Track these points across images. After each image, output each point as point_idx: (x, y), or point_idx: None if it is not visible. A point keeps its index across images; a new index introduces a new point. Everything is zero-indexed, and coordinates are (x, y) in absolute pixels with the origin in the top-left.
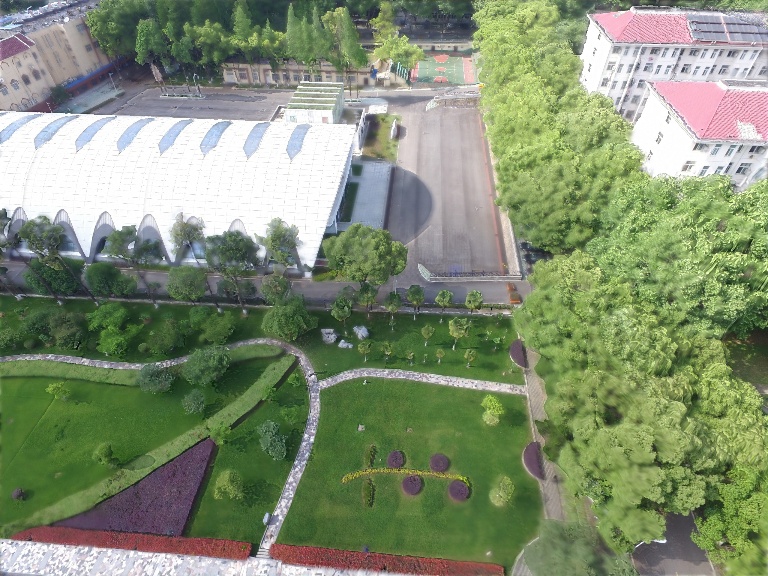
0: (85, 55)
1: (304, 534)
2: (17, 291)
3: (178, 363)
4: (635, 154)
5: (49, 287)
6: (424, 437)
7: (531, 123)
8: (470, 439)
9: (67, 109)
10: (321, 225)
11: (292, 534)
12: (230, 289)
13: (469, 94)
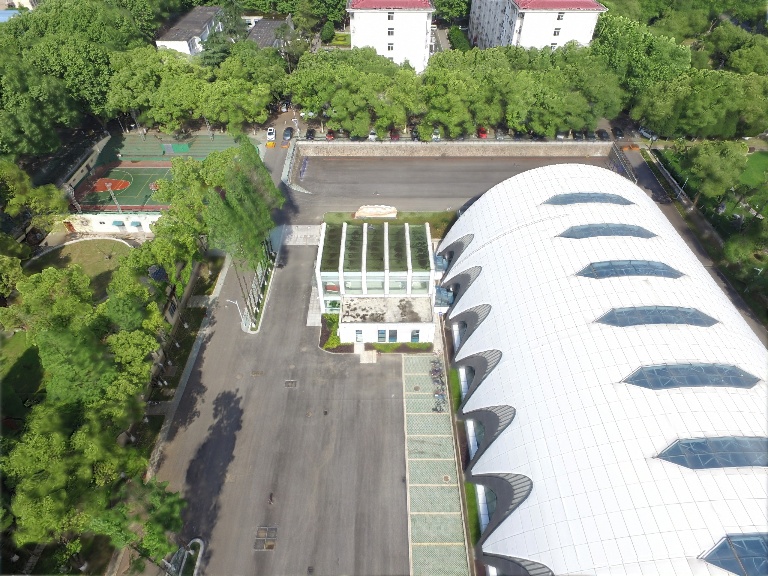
0: None
1: None
2: None
3: None
4: (577, 42)
5: None
6: None
7: None
8: (753, 169)
9: None
10: None
11: None
12: None
13: (294, 153)
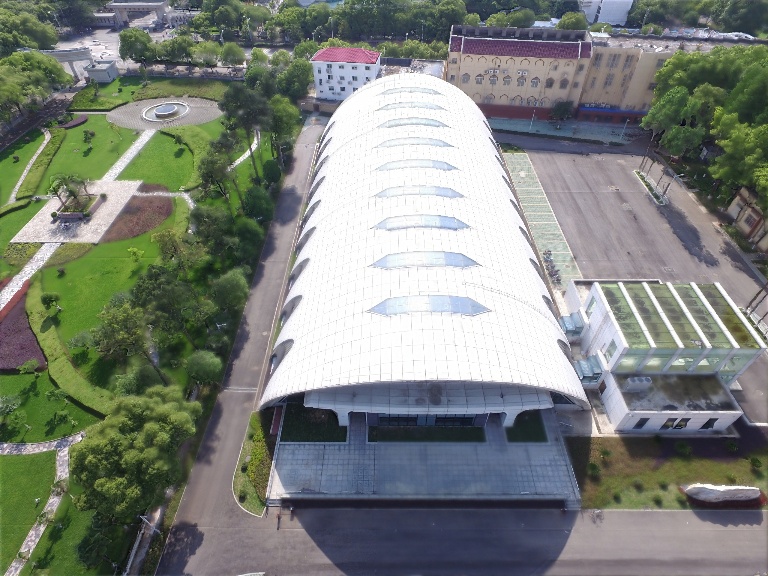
0: (641, 91)
1: None
2: None
3: None
4: None
5: (244, 209)
6: None
7: None
8: None
9: (559, 126)
10: (283, 389)
11: None
12: None
13: None
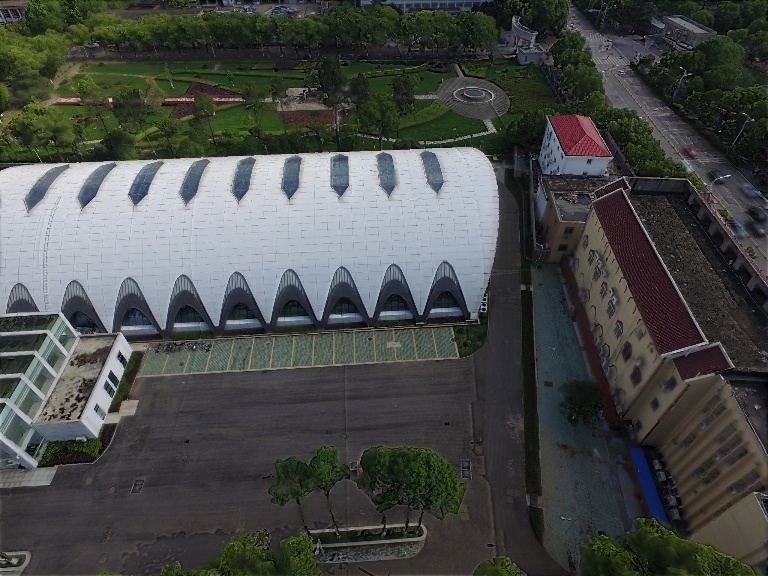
0: None
1: None
2: None
3: None
4: None
5: None
6: None
7: None
8: None
9: (583, 421)
10: None
11: None
12: None
13: None
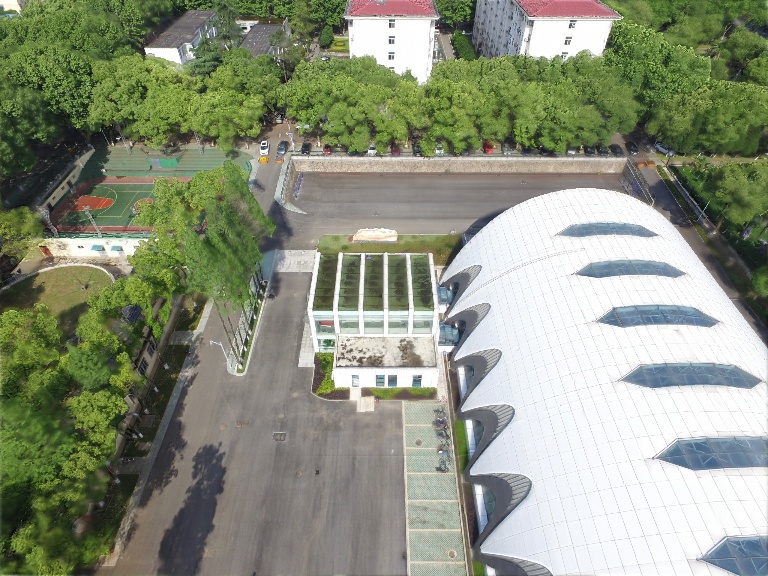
0: None
1: None
2: None
3: None
4: (590, 52)
5: None
6: None
7: None
8: None
9: None
10: None
11: None
12: None
13: (288, 169)
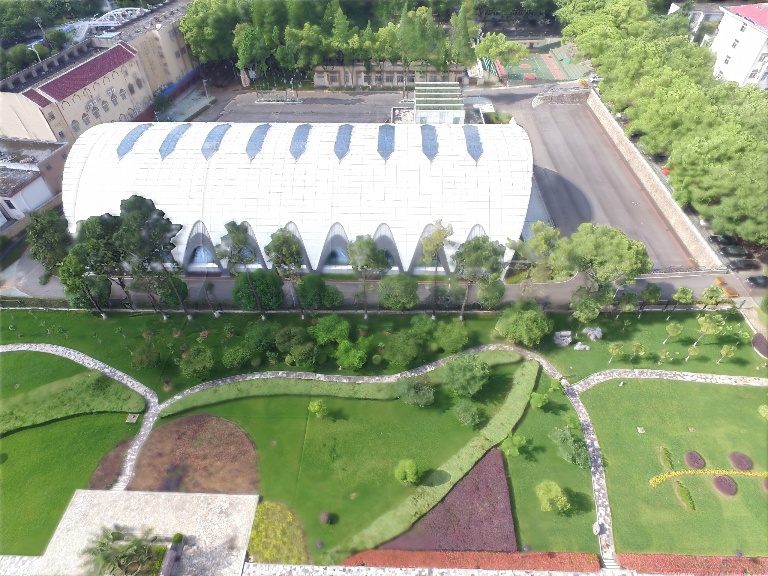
0: (175, 62)
1: (641, 541)
2: (217, 307)
3: (418, 374)
4: None
5: (259, 302)
6: (710, 436)
7: (702, 117)
8: (758, 436)
9: (166, 118)
10: (517, 227)
11: (628, 542)
12: (445, 296)
13: (574, 90)
